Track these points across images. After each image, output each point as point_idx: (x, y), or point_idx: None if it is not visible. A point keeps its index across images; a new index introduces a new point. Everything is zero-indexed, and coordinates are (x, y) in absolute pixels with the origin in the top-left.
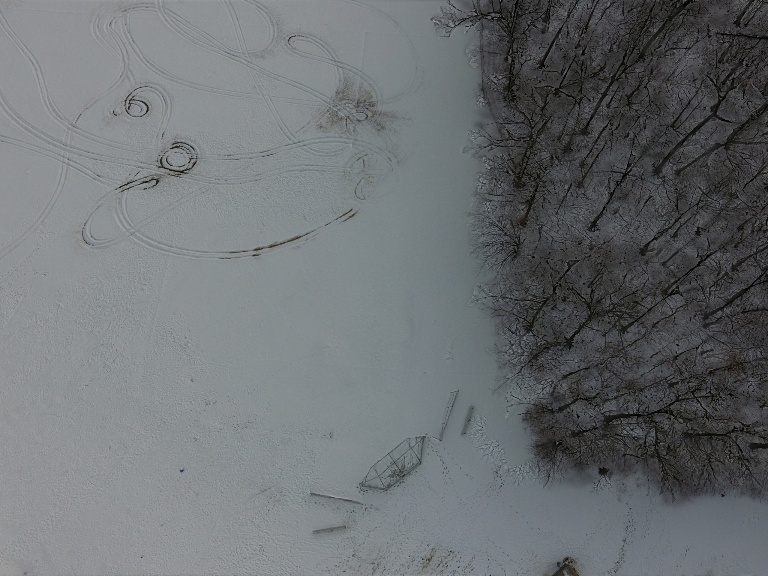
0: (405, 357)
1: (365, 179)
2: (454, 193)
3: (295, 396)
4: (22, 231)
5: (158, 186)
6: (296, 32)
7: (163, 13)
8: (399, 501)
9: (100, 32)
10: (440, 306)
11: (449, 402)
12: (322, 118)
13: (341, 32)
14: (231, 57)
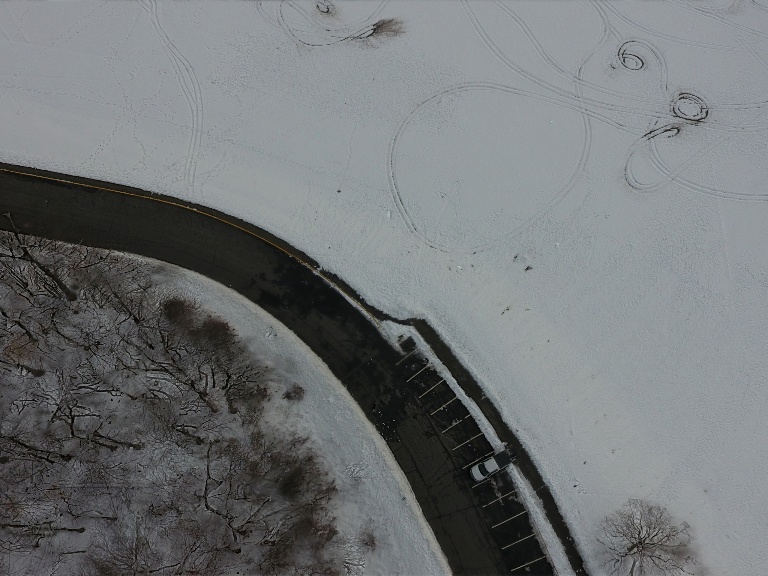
0: None
1: None
2: None
3: None
4: (568, 177)
5: (681, 134)
6: None
7: None
8: None
9: None
10: None
11: None
12: None
13: None
14: (703, 13)
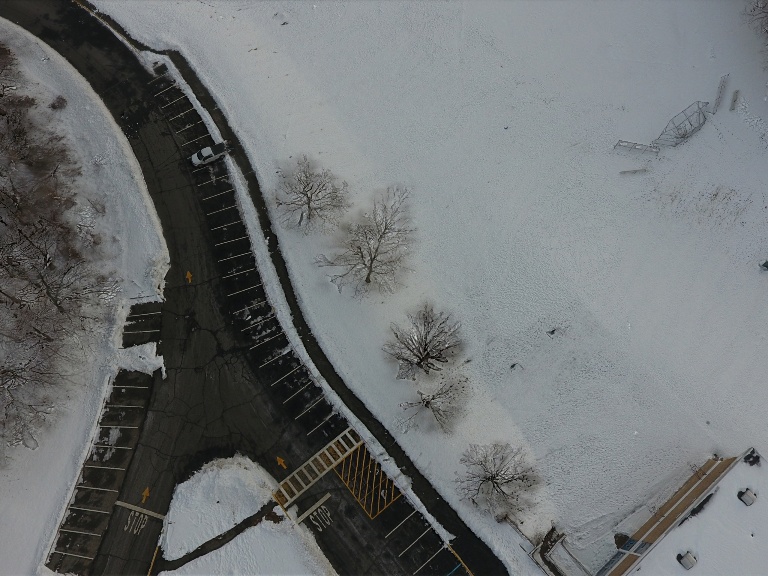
0: (675, 55)
1: None
2: None
3: (589, 80)
4: None
5: None
6: None
7: None
8: (686, 155)
9: None
10: (699, 20)
11: (721, 83)
12: None
13: None
14: None
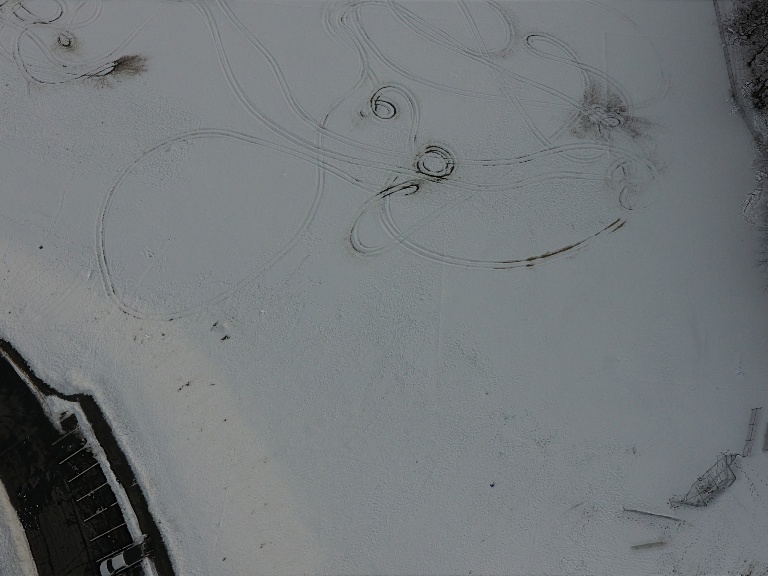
0: (696, 372)
1: (628, 188)
2: (720, 203)
3: (592, 410)
4: (289, 237)
5: (420, 192)
6: (533, 31)
7: (394, 8)
8: (711, 517)
9: (333, 28)
10: (723, 320)
11: (752, 419)
12: (574, 123)
13: (580, 32)
14: (471, 57)
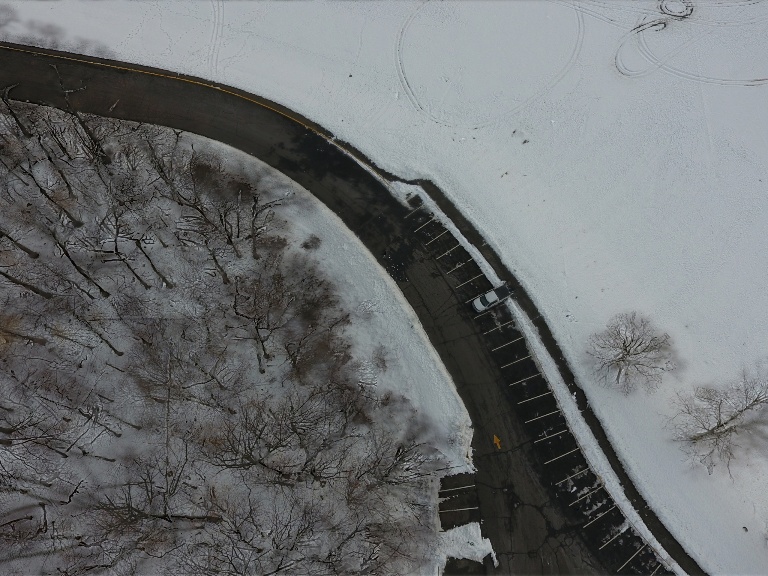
0: None
1: None
2: None
3: None
4: (563, 64)
5: (668, 28)
6: None
7: None
8: None
9: None
10: None
11: None
12: None
13: None
14: None
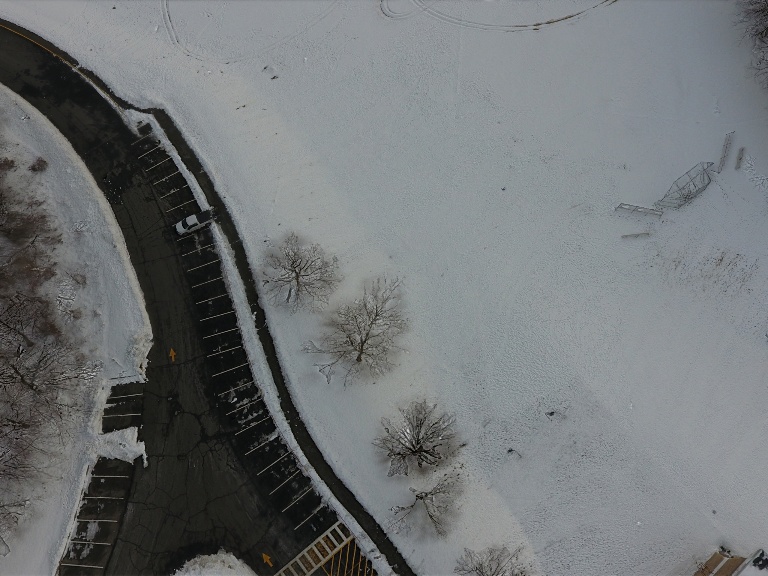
0: (679, 110)
1: None
2: None
3: (589, 137)
4: (328, 4)
5: None
6: None
7: None
8: (690, 217)
9: None
10: (703, 72)
11: (726, 141)
12: None
13: None
14: None
